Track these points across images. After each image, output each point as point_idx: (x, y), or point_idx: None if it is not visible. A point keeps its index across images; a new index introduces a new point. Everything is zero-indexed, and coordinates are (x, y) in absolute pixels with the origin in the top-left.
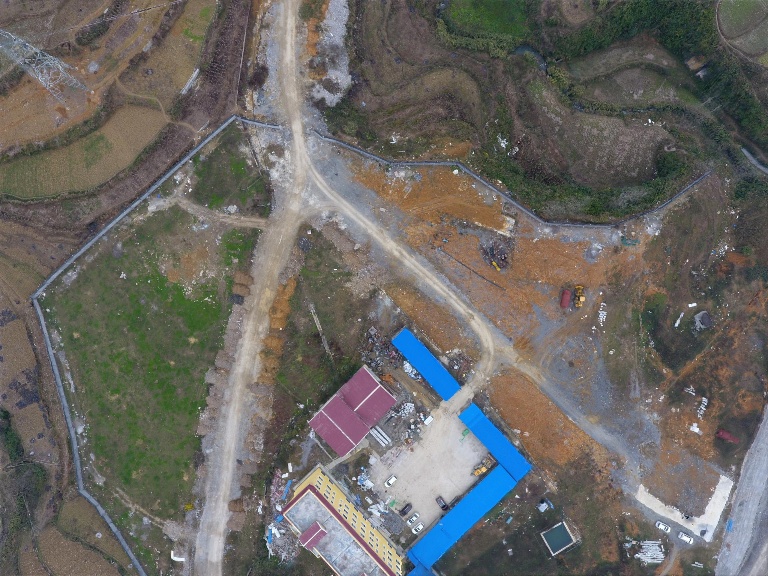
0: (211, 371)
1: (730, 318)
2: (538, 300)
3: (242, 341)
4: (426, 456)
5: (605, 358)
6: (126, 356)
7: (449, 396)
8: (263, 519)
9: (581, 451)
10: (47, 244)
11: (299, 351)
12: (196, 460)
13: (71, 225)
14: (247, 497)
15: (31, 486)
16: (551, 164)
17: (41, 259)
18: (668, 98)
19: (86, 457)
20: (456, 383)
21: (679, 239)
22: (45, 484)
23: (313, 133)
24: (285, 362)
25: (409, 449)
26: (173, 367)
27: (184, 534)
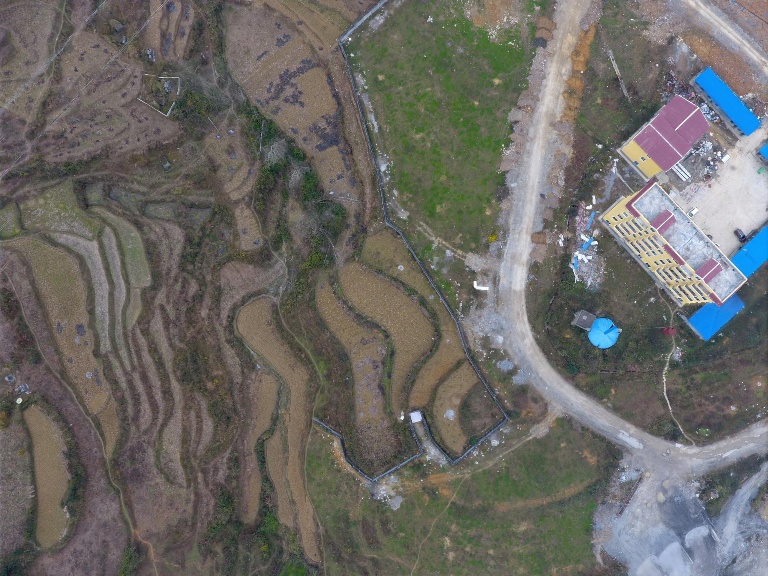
0: (515, 110)
1: None
2: None
3: (546, 82)
4: (723, 192)
5: None
6: (431, 96)
7: (751, 131)
8: (566, 249)
9: None
10: None
11: (598, 94)
12: (499, 195)
13: None
14: (548, 231)
15: (331, 223)
16: None
17: (350, 3)
18: None
19: (389, 193)
20: None
21: None
22: (345, 222)
23: None
24: (585, 104)
25: (707, 185)
26: (477, 107)
27: (487, 265)
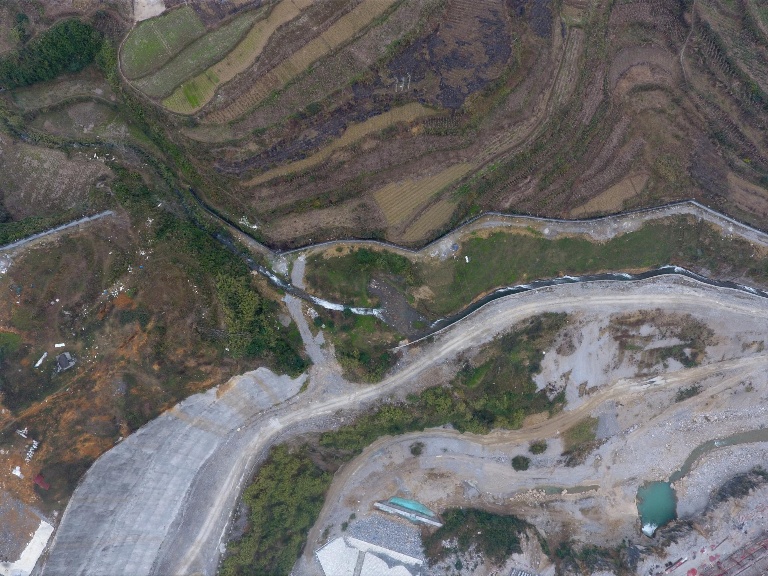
0: None
1: (97, 360)
2: None
3: None
4: None
5: None
6: None
7: None
8: None
9: None
10: None
11: None
12: None
13: None
14: None
15: None
16: None
17: None
18: (119, 134)
19: None
20: None
21: (37, 278)
22: None
23: None
24: None
25: None
26: None
27: None
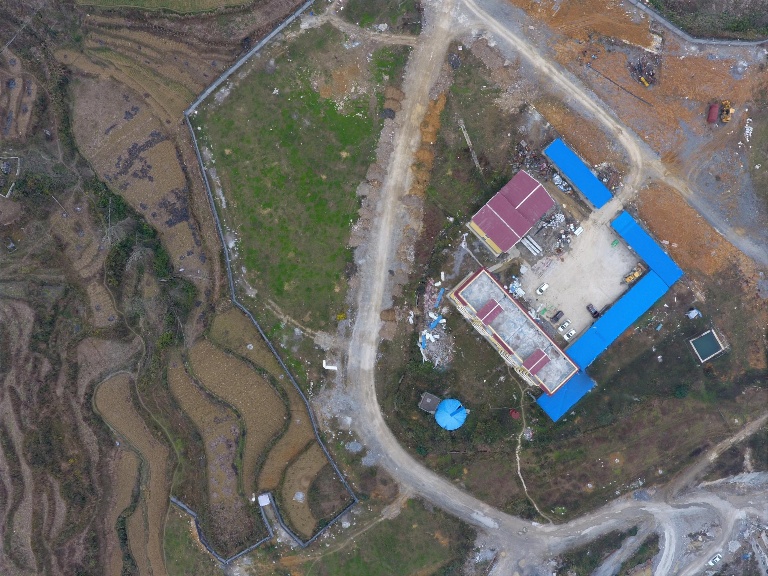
0: (363, 184)
1: None
2: (685, 116)
3: (394, 154)
4: (576, 266)
5: (751, 172)
6: (278, 170)
7: (602, 204)
8: (415, 327)
9: (728, 262)
10: (200, 61)
11: (449, 165)
12: (348, 271)
13: (226, 40)
14: (398, 307)
15: (181, 301)
16: (680, 5)
17: (194, 76)
18: None
19: (237, 271)
20: (608, 191)
21: None
22: (195, 299)
23: None
24: (435, 176)
25: (559, 259)
26: (325, 181)
27: (336, 343)
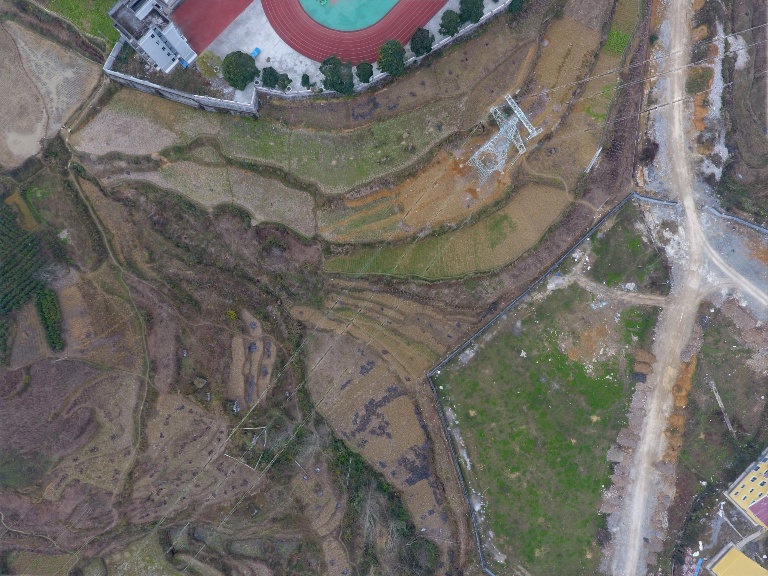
0: (615, 449)
1: None
2: None
3: (647, 419)
4: None
5: None
6: (527, 434)
7: None
8: None
9: None
10: (444, 322)
11: (701, 428)
12: (601, 538)
13: (475, 305)
14: (652, 575)
15: None
16: None
17: (438, 337)
18: None
19: (484, 534)
20: None
21: None
22: (439, 561)
23: (706, 209)
24: (688, 440)
25: None
26: (575, 445)
27: None
